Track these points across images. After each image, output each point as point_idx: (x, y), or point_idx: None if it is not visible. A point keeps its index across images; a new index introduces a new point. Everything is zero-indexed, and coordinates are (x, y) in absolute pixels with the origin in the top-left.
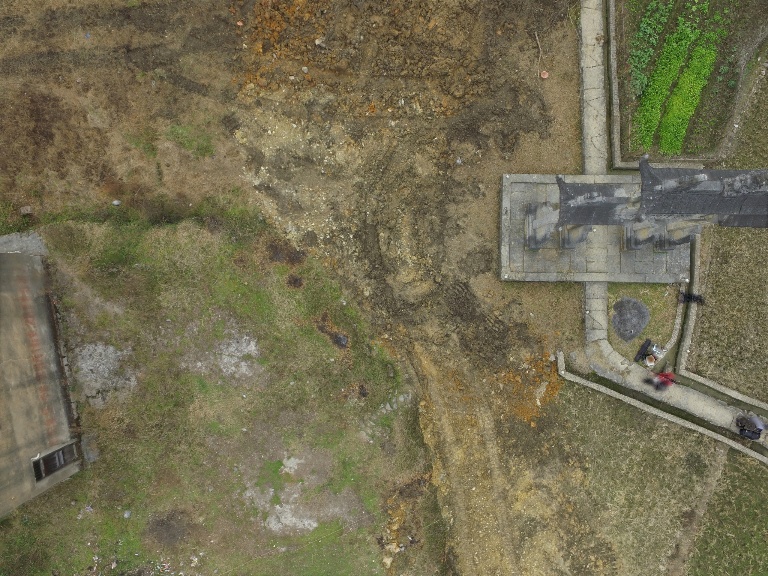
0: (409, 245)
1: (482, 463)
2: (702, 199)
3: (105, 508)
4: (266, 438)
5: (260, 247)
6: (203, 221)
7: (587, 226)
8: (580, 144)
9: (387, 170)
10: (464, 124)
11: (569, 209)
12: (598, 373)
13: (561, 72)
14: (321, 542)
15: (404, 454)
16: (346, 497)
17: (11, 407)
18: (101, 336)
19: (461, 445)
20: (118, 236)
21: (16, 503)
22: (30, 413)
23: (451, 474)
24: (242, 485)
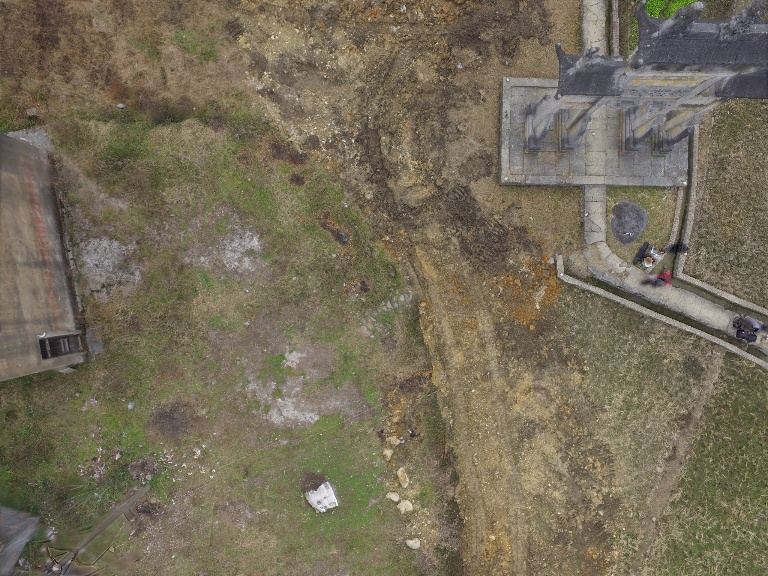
0: (410, 151)
1: (482, 365)
2: (698, 46)
3: (109, 400)
4: (268, 332)
5: (263, 145)
6: (207, 122)
7: (586, 116)
8: (580, 50)
9: (389, 76)
10: (465, 30)
11: (568, 77)
12: (596, 275)
13: None
14: (322, 435)
15: (405, 351)
16: (347, 391)
17: (18, 281)
18: (106, 231)
19: (461, 348)
20: (123, 133)
21: (23, 371)
22: (36, 293)
23: (451, 376)
24: (244, 378)
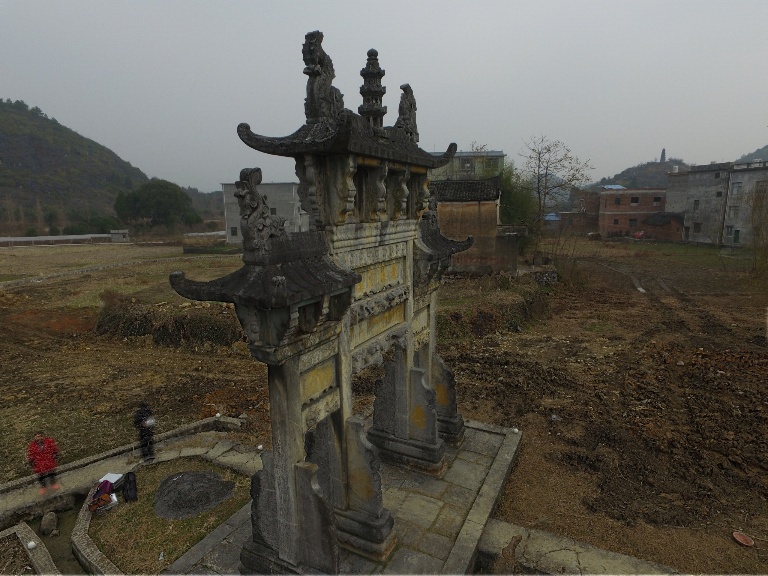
0: None
1: None
2: None
3: None
4: None
5: None
6: None
7: None
8: None
9: None
10: None
11: None
12: None
13: (764, 572)
14: None
15: None
16: None
17: None
18: None
19: None
20: None
21: None
22: None
23: None
24: None
